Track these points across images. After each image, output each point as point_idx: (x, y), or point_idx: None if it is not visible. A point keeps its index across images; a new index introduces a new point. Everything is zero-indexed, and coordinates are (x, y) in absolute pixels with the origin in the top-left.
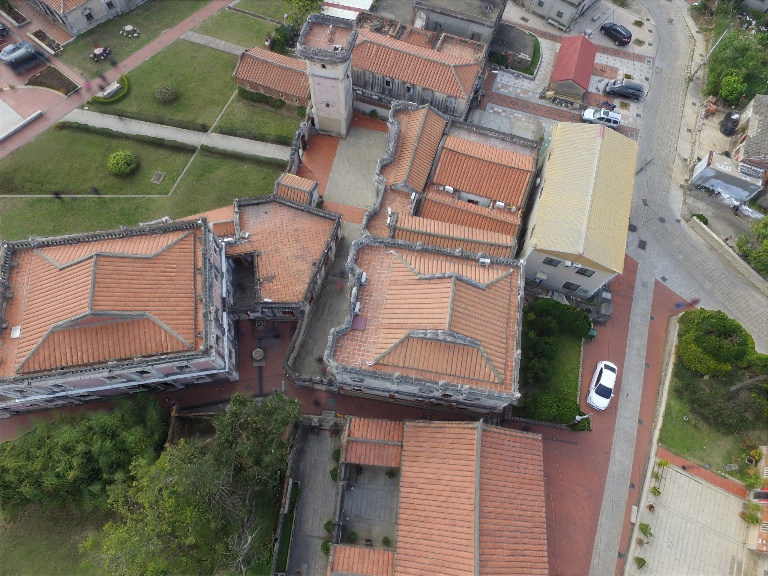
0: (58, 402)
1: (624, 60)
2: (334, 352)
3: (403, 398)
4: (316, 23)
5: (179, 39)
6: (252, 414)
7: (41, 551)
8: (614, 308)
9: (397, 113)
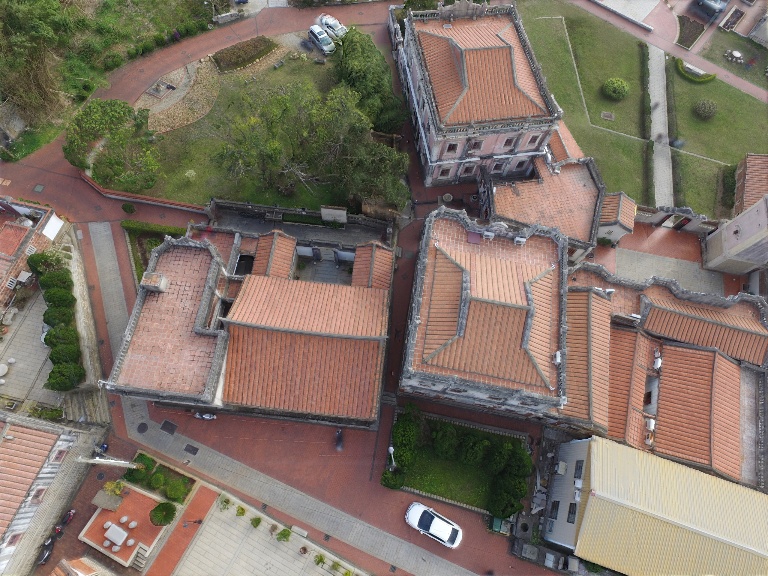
0: None
1: None
2: (446, 219)
3: None
4: None
5: None
6: (392, 167)
7: None
8: (535, 575)
9: (752, 306)
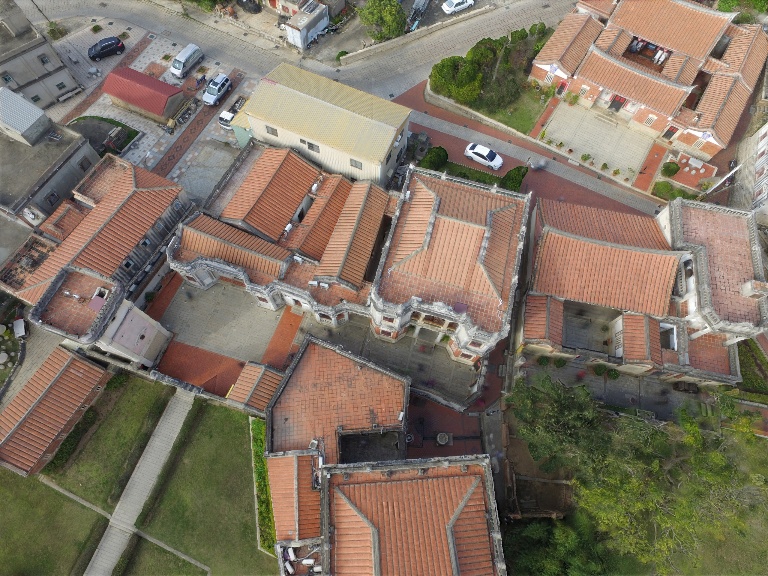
0: None
1: (143, 54)
2: None
3: None
4: (41, 317)
5: None
6: None
7: None
8: None
9: None
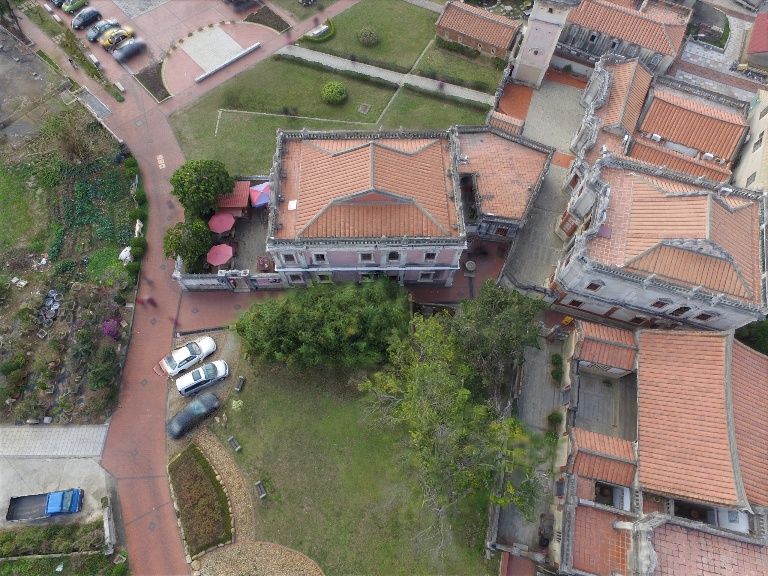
0: (298, 281)
1: None
2: None
3: (618, 317)
4: None
5: None
6: None
7: (288, 403)
8: None
9: None
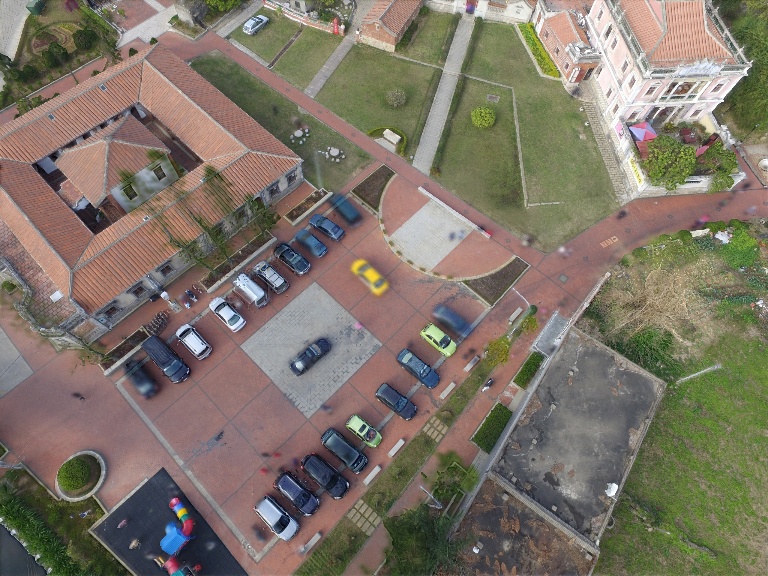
0: None
1: None
2: None
3: None
4: None
5: (315, 99)
6: None
7: None
8: None
9: None
